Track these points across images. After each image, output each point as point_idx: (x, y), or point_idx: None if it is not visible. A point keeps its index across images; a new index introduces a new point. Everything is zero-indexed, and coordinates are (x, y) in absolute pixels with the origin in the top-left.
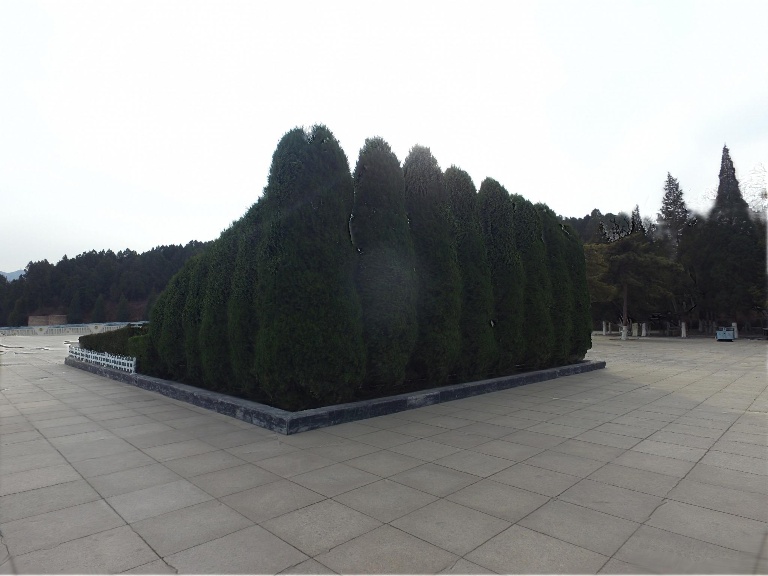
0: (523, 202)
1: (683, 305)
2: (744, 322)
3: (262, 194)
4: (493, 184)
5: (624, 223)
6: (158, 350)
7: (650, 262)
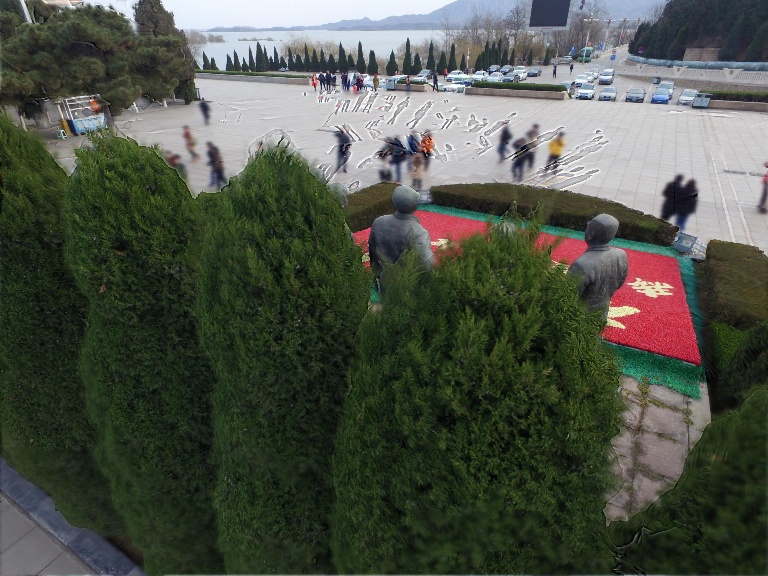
0: (425, 325)
1: None
2: None
3: None
4: None
5: None
6: None
7: None
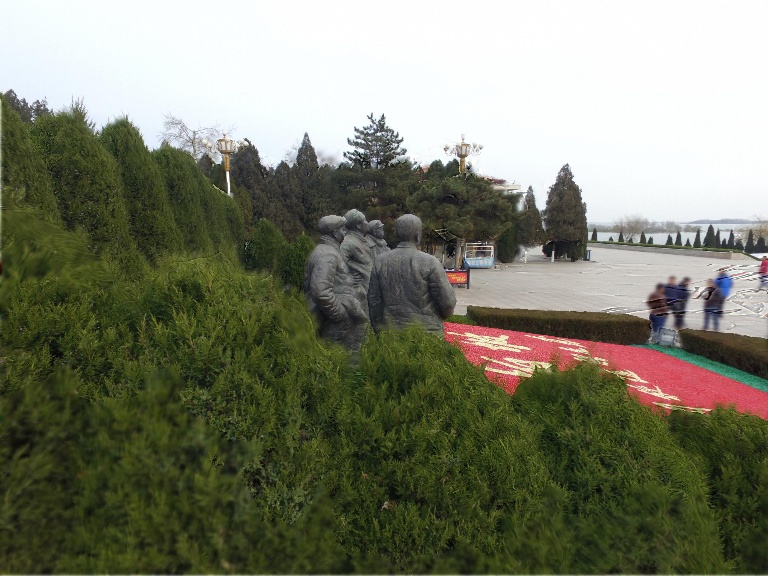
0: None
1: None
2: None
3: None
4: None
5: None
6: None
7: None
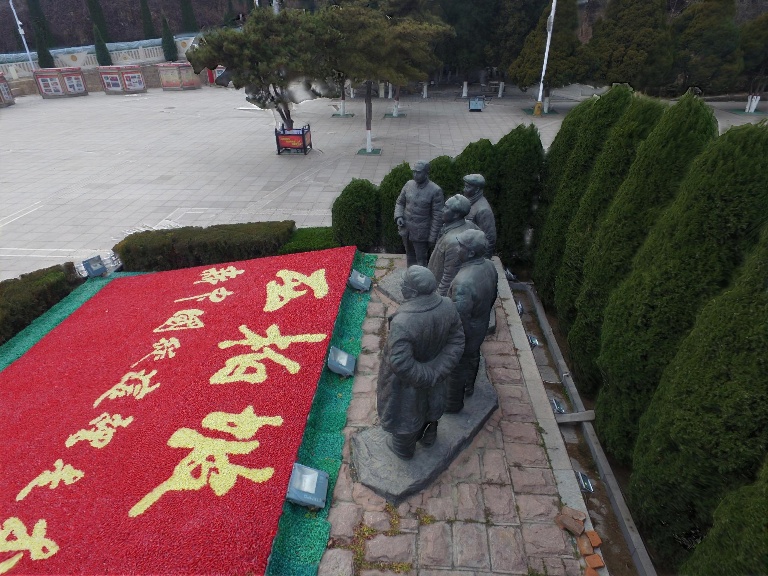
0: None
1: (448, 75)
2: (473, 81)
3: None
4: (712, 120)
5: None
6: None
7: None
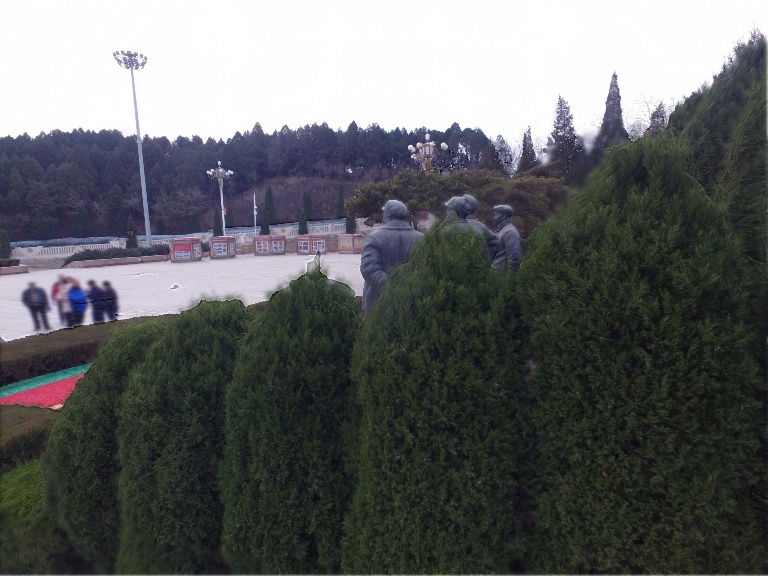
0: None
1: None
2: None
3: (623, 172)
4: None
5: (516, 145)
6: (99, 568)
7: (559, 192)
